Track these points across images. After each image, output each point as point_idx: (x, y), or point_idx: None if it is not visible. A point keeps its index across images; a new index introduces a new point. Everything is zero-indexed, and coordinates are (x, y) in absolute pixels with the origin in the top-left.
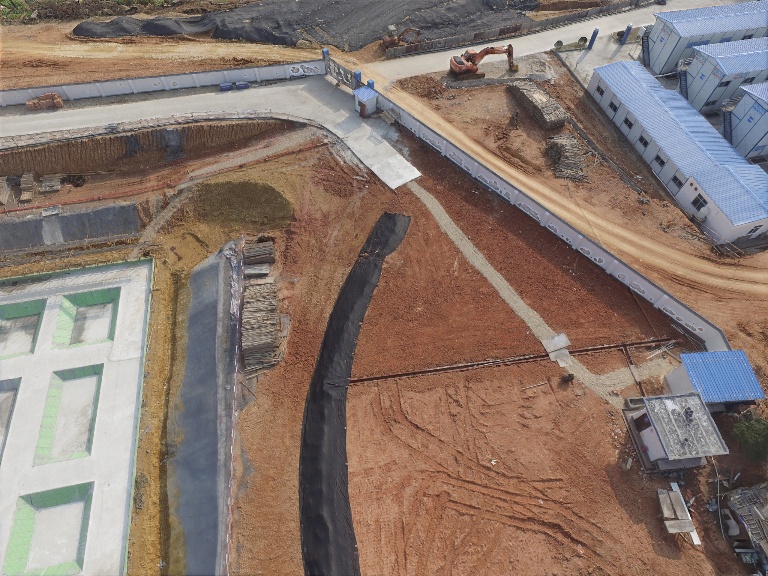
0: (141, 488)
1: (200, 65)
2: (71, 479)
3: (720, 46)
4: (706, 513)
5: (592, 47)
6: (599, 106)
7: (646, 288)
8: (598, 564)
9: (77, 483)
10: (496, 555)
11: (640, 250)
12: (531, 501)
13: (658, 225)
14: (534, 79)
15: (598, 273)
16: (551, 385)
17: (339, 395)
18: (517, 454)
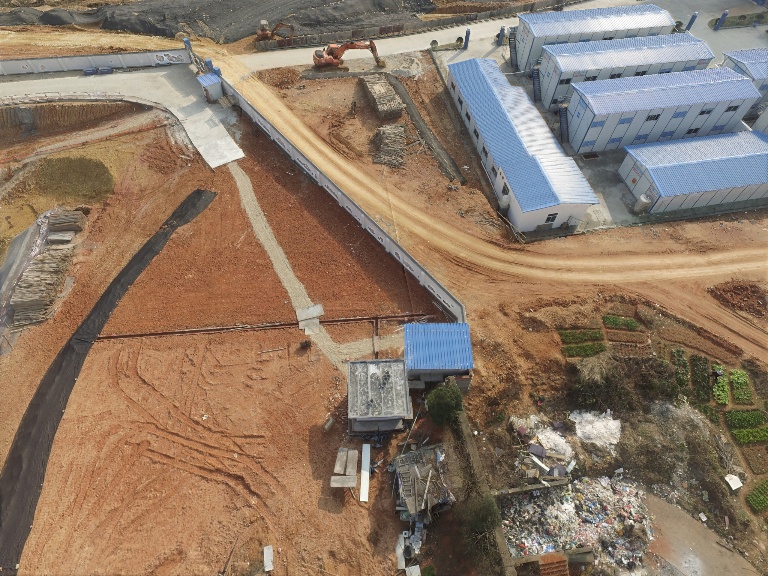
0: None
1: (77, 52)
2: None
3: (568, 46)
4: (386, 473)
5: (468, 47)
6: (453, 101)
7: (412, 265)
8: (262, 514)
9: None
10: (172, 501)
11: (431, 232)
12: (226, 454)
13: (458, 210)
14: (398, 75)
15: (379, 251)
16: (289, 350)
17: (82, 349)
18: (230, 411)
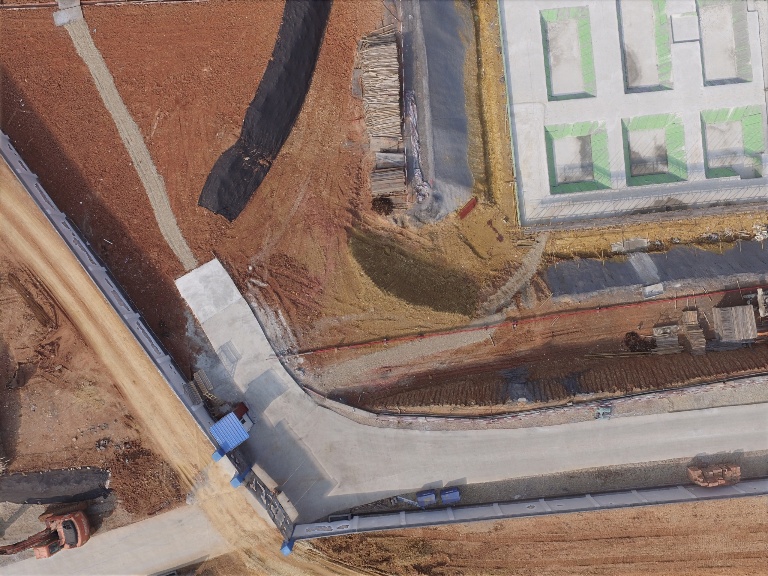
0: None
1: (500, 567)
2: None
3: None
4: None
5: None
6: None
7: None
8: None
9: None
10: None
11: None
12: None
13: None
14: None
15: None
16: None
17: None
18: None
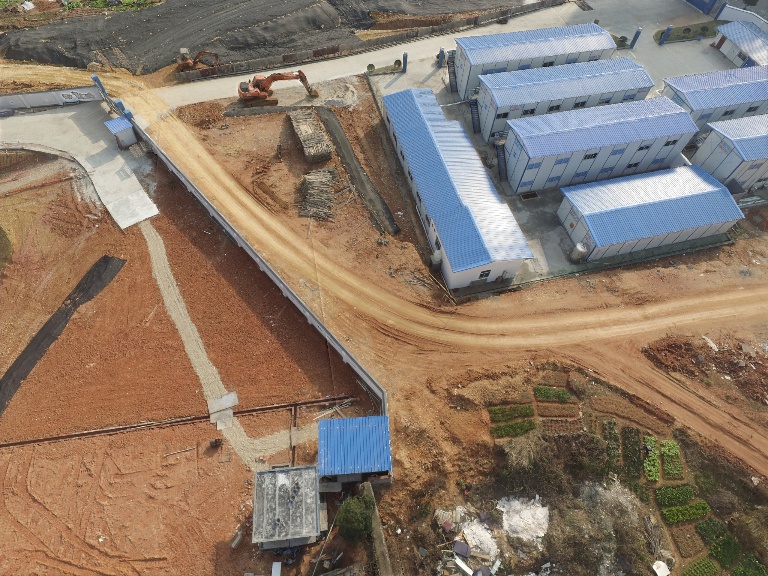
0: None
1: None
2: None
3: (505, 75)
4: None
5: (407, 70)
6: (389, 135)
7: None
8: None
9: None
10: None
11: (358, 297)
12: None
13: (387, 269)
14: (332, 105)
15: (300, 323)
16: (198, 450)
17: None
18: (130, 530)
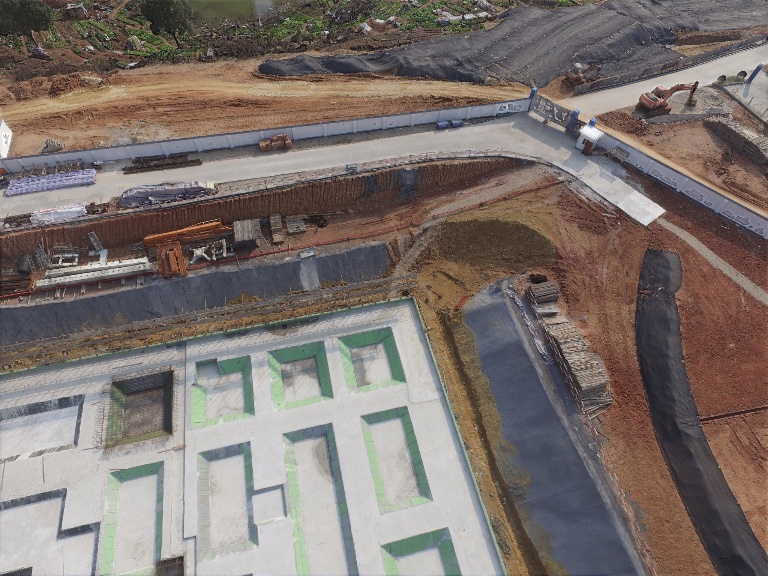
0: (501, 533)
1: (402, 103)
2: (424, 526)
3: None
4: None
5: (751, 81)
6: None
7: None
8: None
9: (432, 530)
10: None
11: None
12: None
13: None
14: None
15: None
16: None
17: (697, 434)
18: None
